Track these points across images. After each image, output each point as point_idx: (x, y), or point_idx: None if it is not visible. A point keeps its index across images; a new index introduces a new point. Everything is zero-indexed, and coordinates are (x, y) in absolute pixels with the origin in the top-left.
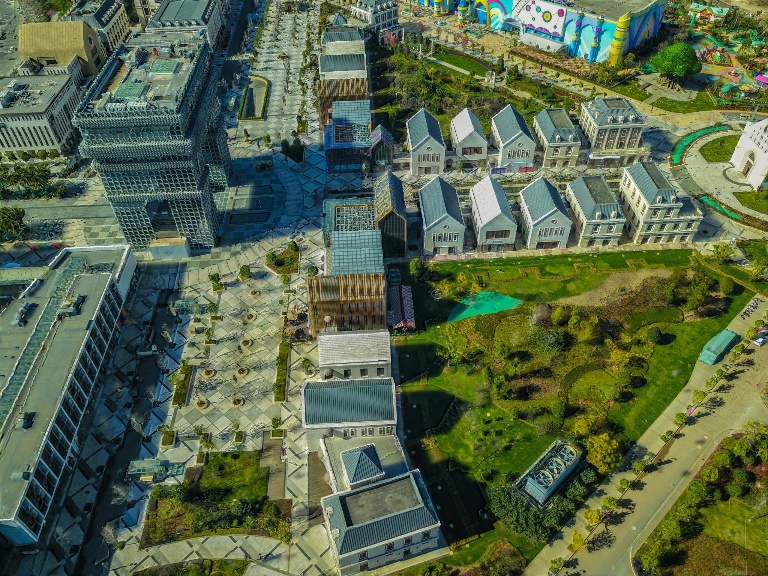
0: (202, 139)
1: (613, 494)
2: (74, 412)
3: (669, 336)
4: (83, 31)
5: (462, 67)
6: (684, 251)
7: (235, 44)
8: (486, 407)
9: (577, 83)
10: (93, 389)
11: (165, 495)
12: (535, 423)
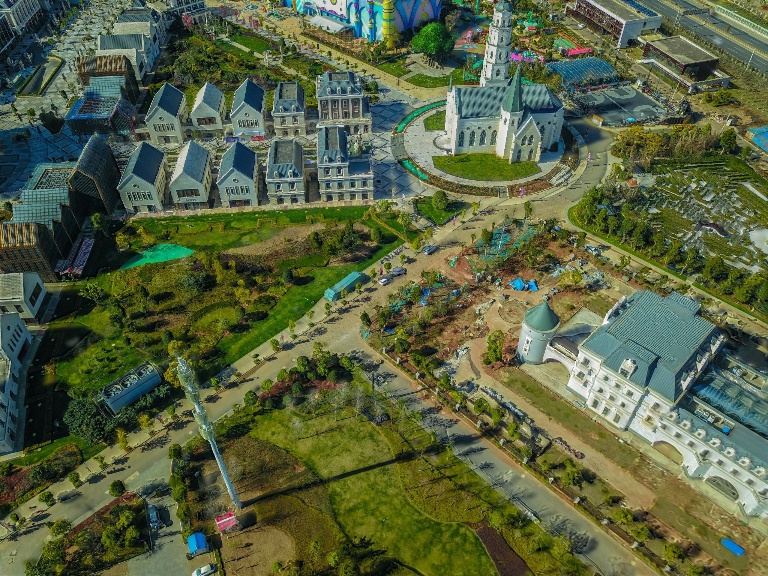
0: None
1: (187, 406)
2: None
3: (308, 278)
4: None
5: (250, 47)
6: (363, 207)
7: None
8: (114, 339)
9: None
10: None
11: None
12: (146, 350)
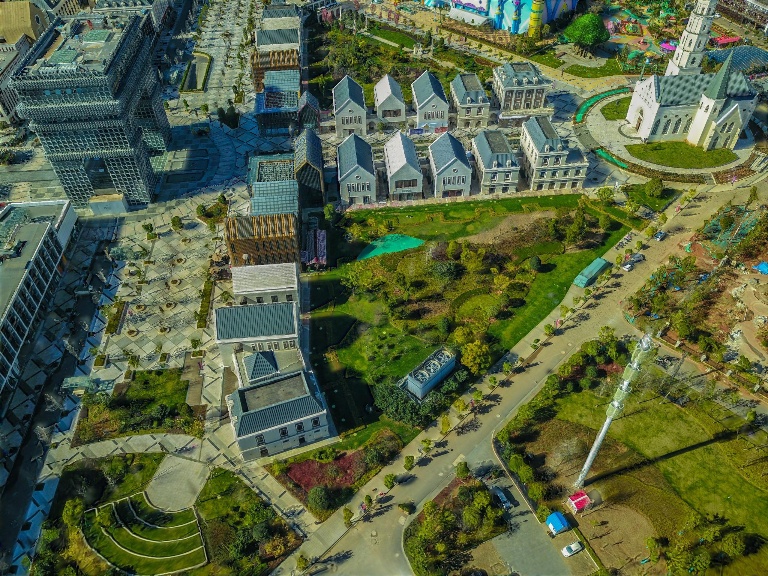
0: (134, 103)
1: (484, 391)
2: (14, 338)
3: (550, 265)
4: (30, 11)
5: (393, 41)
6: (574, 196)
7: (181, 24)
8: (383, 327)
9: (498, 53)
10: (34, 323)
11: (93, 402)
12: (423, 337)
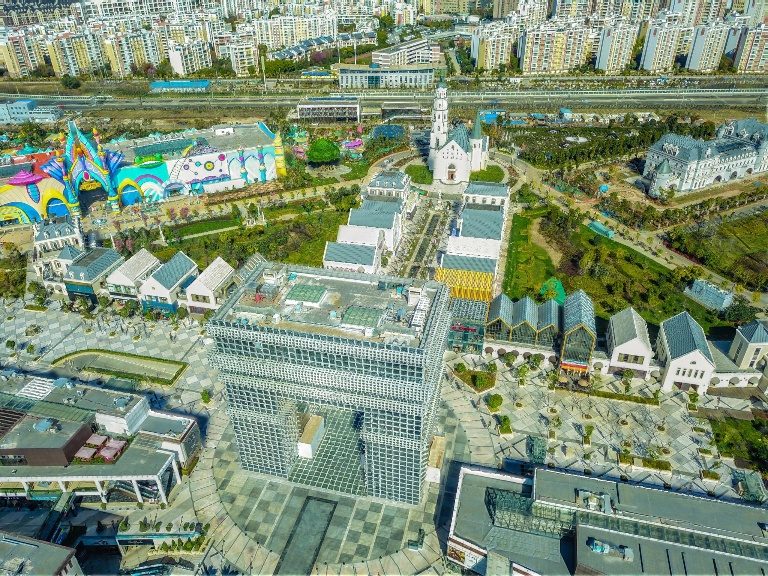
0: None
1: None
2: None
3: (591, 241)
4: None
5: (209, 230)
6: (516, 216)
7: None
8: None
9: None
10: None
11: None
12: None
